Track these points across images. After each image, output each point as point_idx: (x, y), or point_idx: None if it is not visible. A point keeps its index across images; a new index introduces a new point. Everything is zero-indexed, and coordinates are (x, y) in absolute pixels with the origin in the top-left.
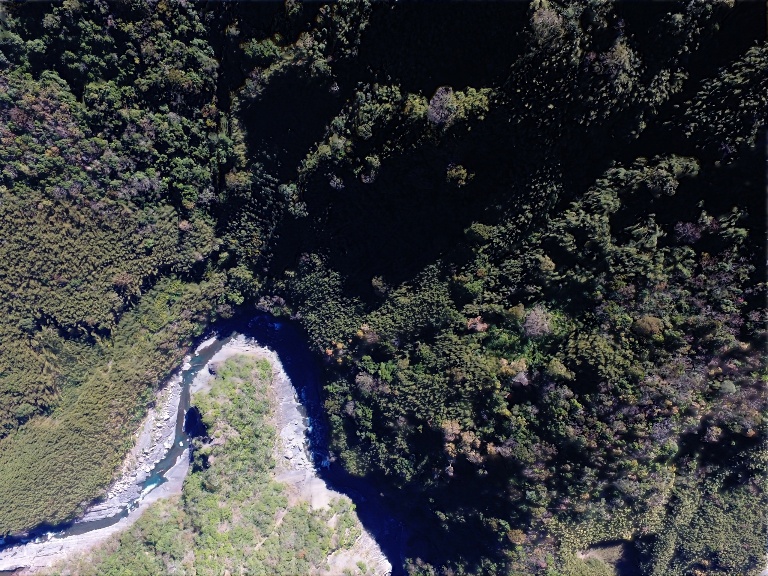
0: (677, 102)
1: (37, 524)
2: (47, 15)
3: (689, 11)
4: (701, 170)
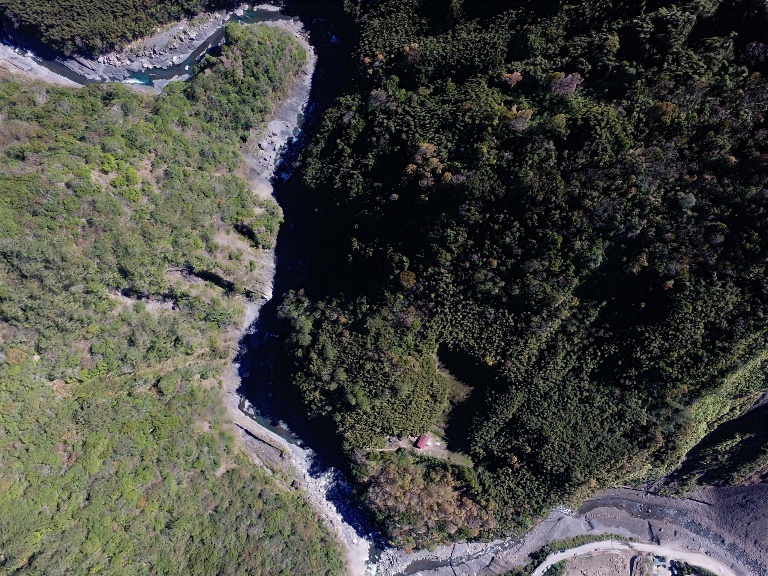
0: None
1: (30, 21)
2: None
3: None
4: None
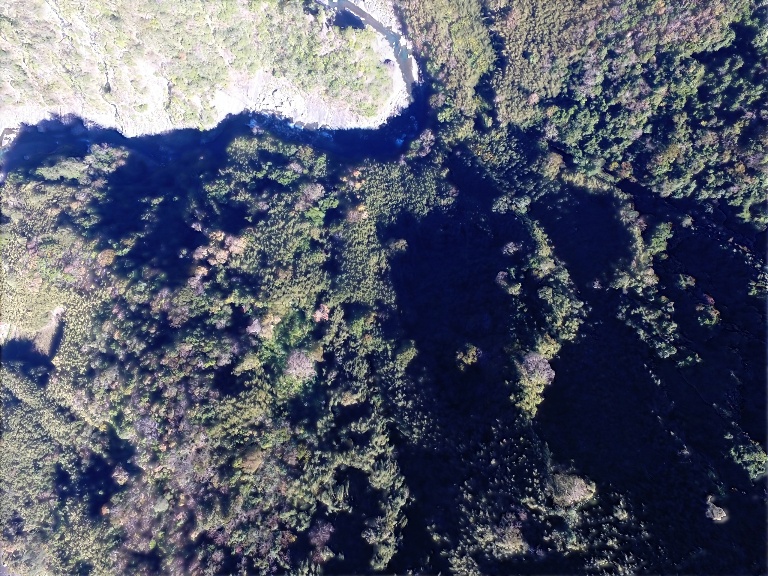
0: (443, 575)
1: None
2: None
3: None
4: (372, 569)
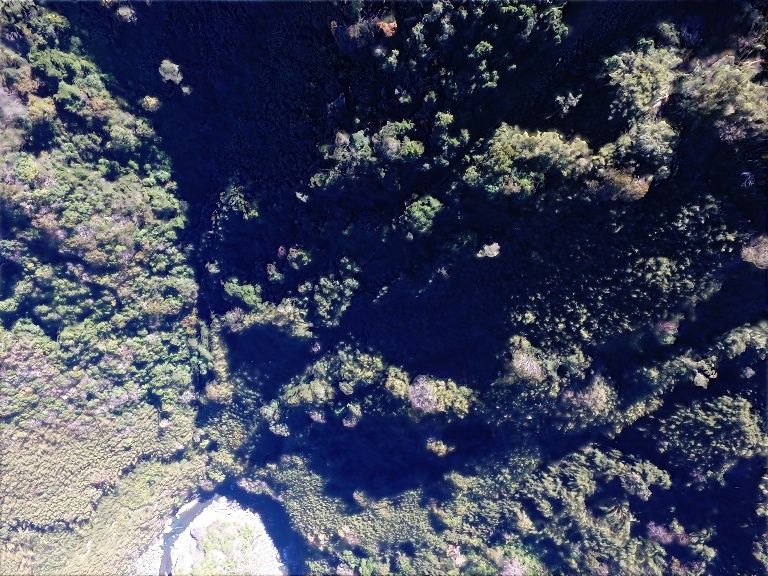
0: (652, 413)
1: None
2: (18, 283)
3: (664, 369)
4: (673, 483)
